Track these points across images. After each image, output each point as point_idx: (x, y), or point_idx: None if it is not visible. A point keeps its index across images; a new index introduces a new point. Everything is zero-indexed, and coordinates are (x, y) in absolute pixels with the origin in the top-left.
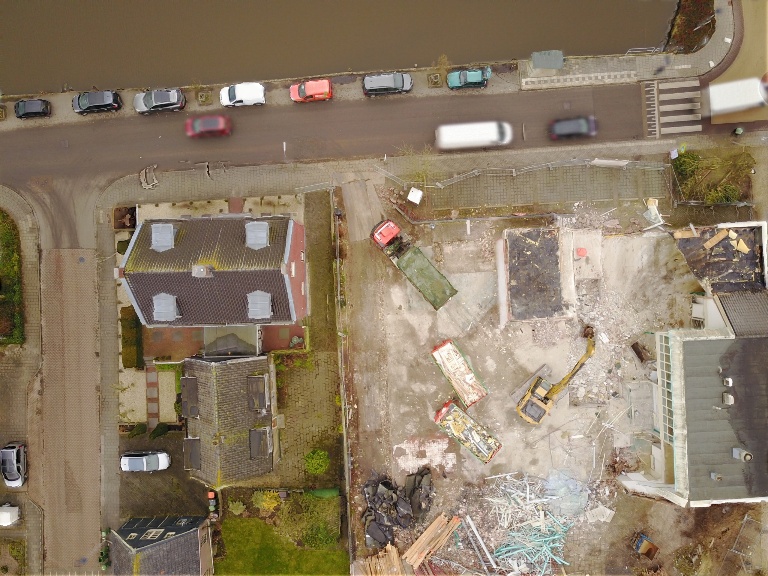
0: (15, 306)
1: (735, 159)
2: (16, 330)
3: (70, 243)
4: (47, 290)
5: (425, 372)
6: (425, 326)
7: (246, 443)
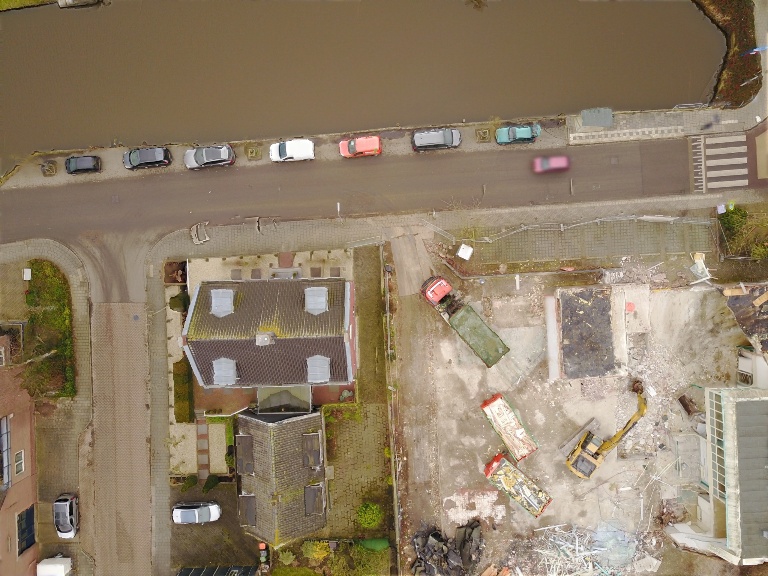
0: (67, 360)
1: None
2: (68, 384)
3: (120, 297)
4: (97, 343)
5: (475, 425)
6: (475, 380)
7: (301, 500)
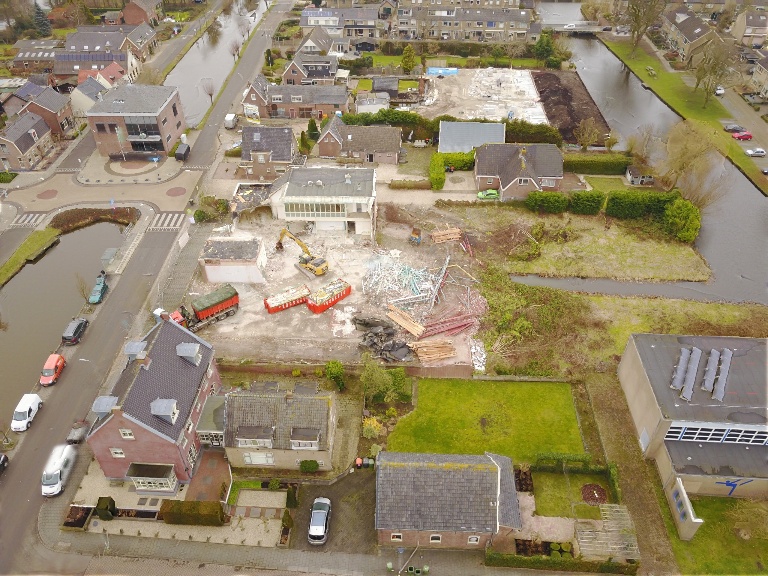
0: None
1: (206, 204)
2: None
3: None
4: None
5: (285, 318)
6: (252, 317)
7: None
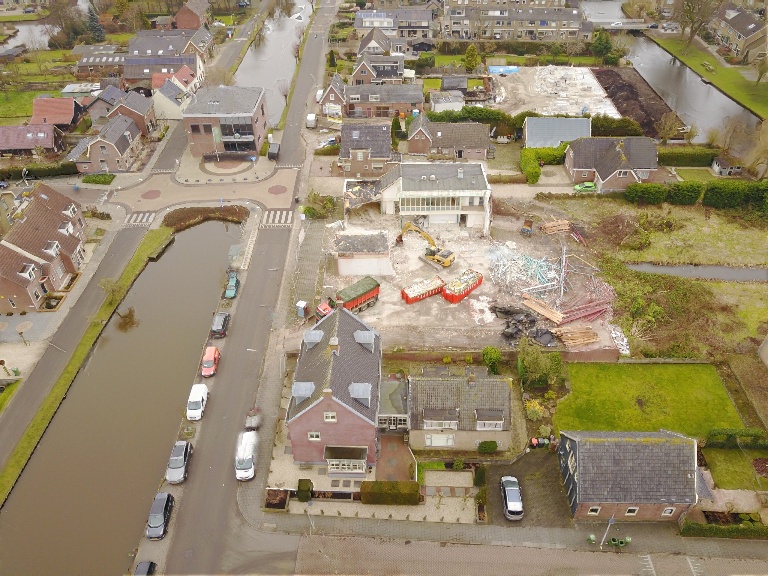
0: None
1: None
2: None
3: (290, 561)
4: None
5: (424, 308)
6: (392, 307)
7: None
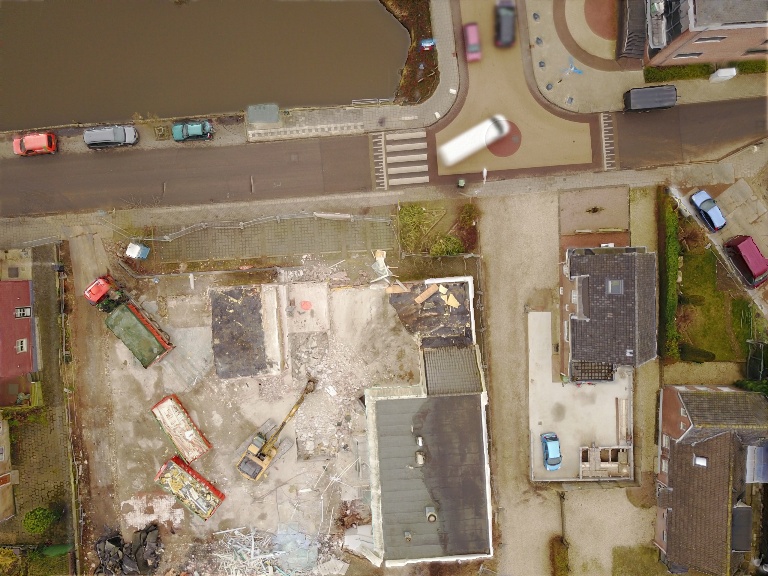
0: None
1: (462, 210)
2: None
3: None
4: None
5: (151, 427)
6: (151, 381)
7: None
